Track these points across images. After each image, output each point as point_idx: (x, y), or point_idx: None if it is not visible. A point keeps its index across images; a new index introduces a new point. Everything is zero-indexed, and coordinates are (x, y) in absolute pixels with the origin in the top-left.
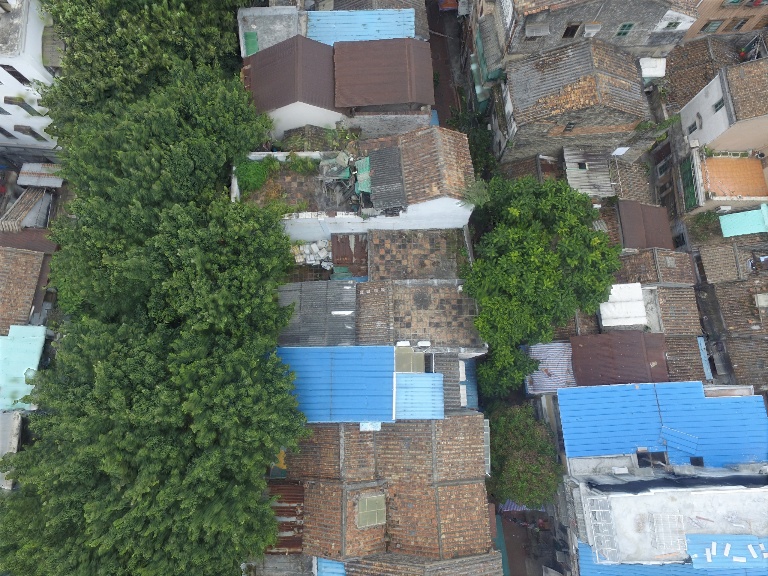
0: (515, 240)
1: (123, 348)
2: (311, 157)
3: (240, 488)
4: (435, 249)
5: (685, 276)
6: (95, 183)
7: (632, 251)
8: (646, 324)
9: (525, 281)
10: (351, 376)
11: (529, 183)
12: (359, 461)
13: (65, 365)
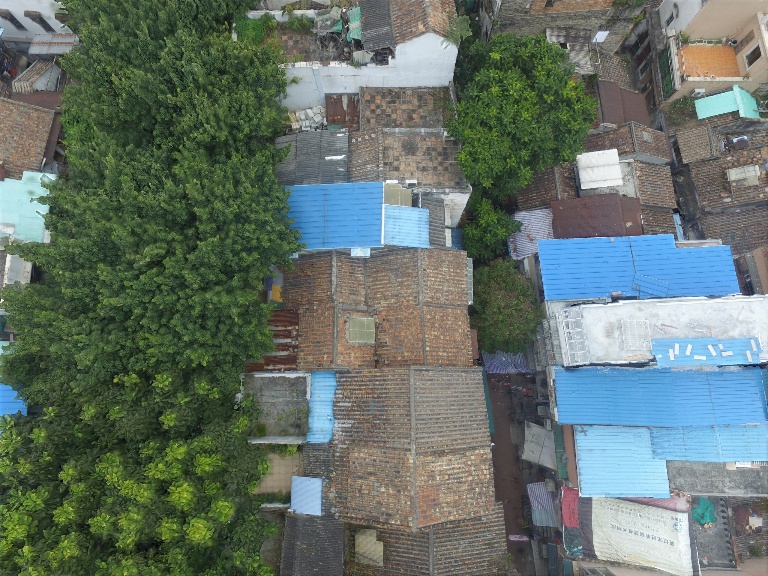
0: (496, 79)
1: (131, 161)
2: (306, 15)
3: (239, 283)
4: (423, 105)
5: (661, 152)
6: (105, 14)
7: (610, 126)
8: (623, 194)
9: (504, 113)
10: (343, 209)
11: None
12: (350, 290)
13: (77, 177)
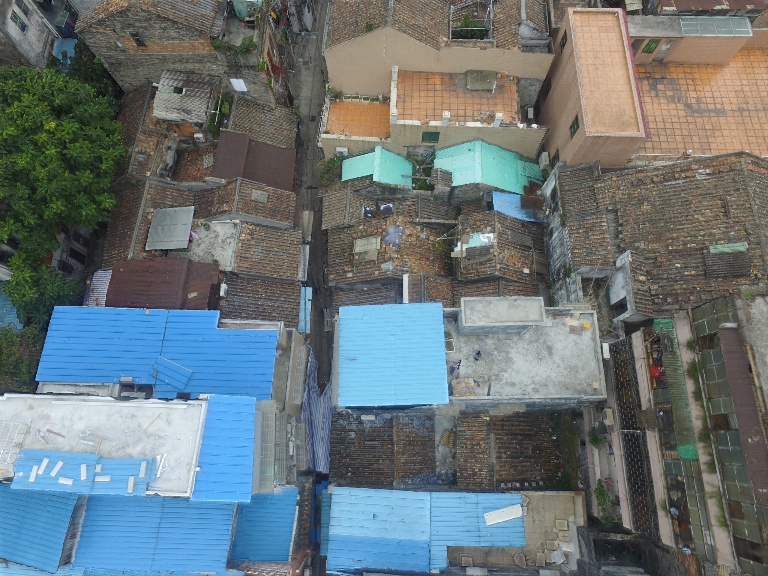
0: None
1: None
2: None
3: None
4: None
5: (280, 214)
6: None
7: (217, 181)
8: (218, 258)
9: None
10: None
11: (17, 70)
12: None
13: None
